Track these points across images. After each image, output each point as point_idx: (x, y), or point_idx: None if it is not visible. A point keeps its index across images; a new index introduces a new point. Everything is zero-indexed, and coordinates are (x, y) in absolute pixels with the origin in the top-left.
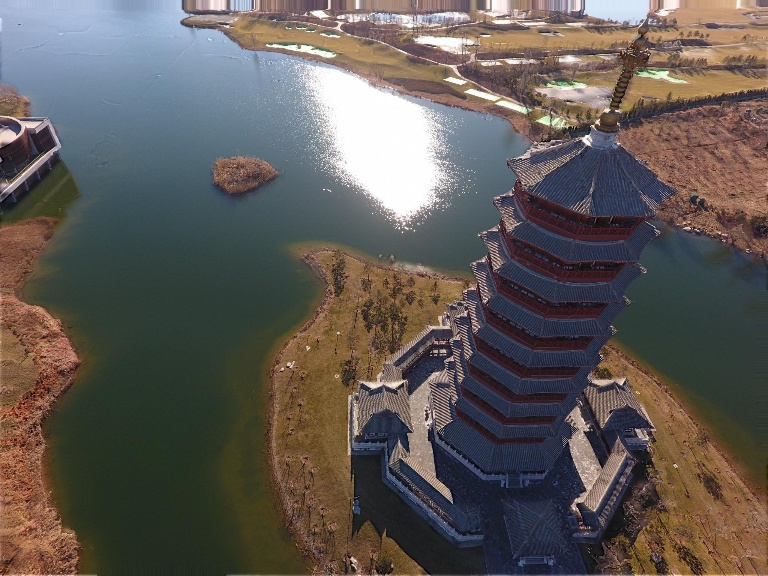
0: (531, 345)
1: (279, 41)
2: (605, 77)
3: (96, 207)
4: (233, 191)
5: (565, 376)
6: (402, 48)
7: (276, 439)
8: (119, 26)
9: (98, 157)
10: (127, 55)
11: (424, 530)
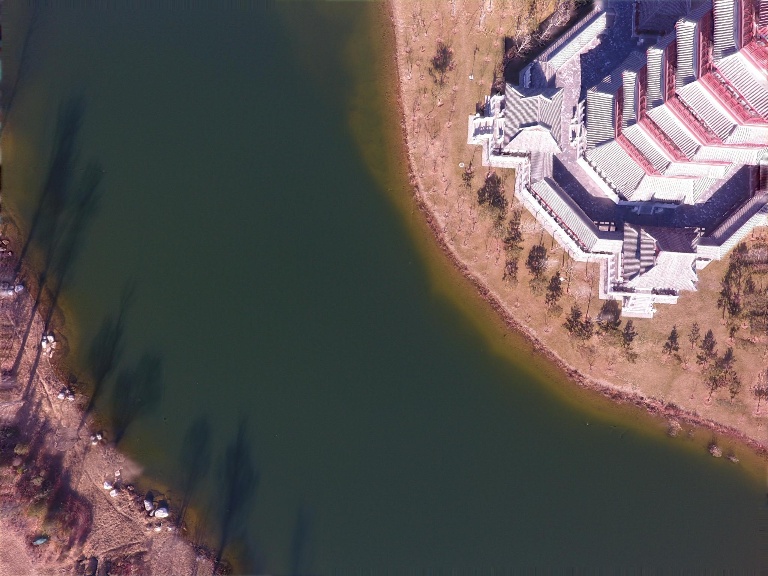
0: None
1: None
2: None
3: None
4: None
5: None
6: None
7: None
8: None
9: None
10: None
11: None
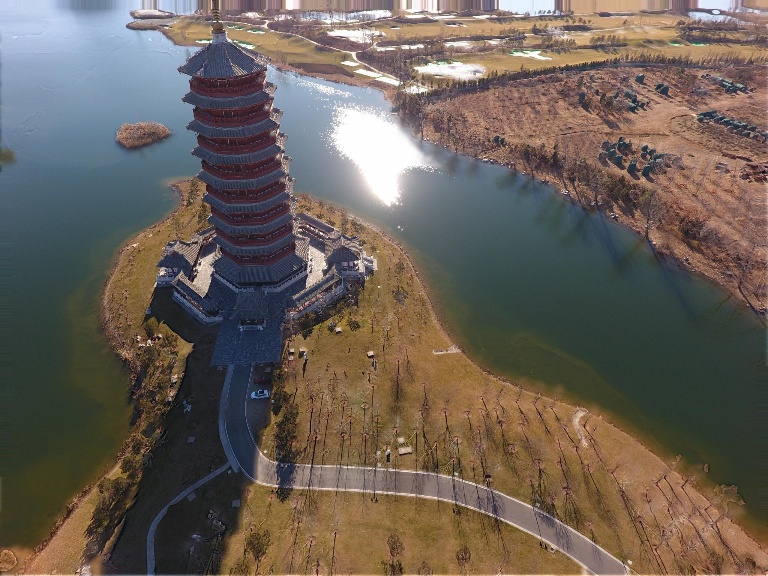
0: (219, 176)
1: (208, 37)
2: (481, 57)
3: None
4: (129, 145)
5: (254, 201)
6: (315, 40)
7: (111, 284)
8: (70, 30)
9: (26, 126)
10: (70, 52)
11: (189, 320)
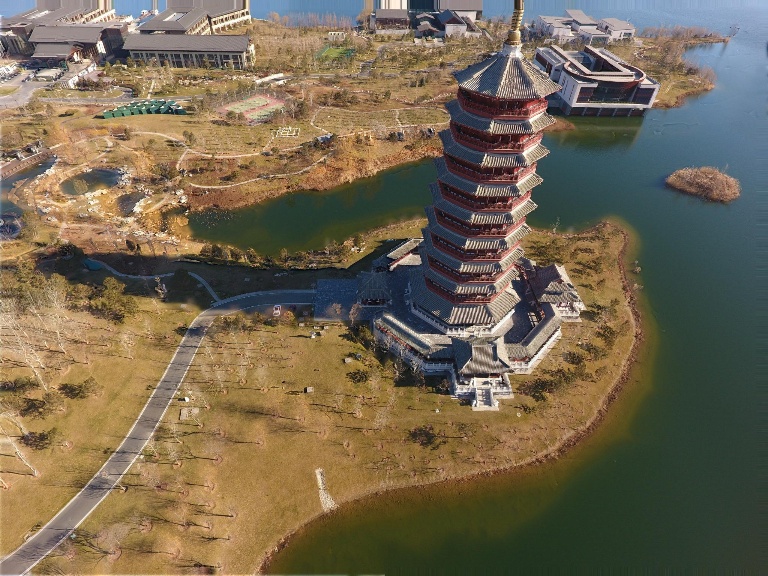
0: None
1: None
2: None
3: (603, 140)
4: (669, 181)
5: None
6: None
7: None
8: None
9: (661, 126)
10: None
11: None
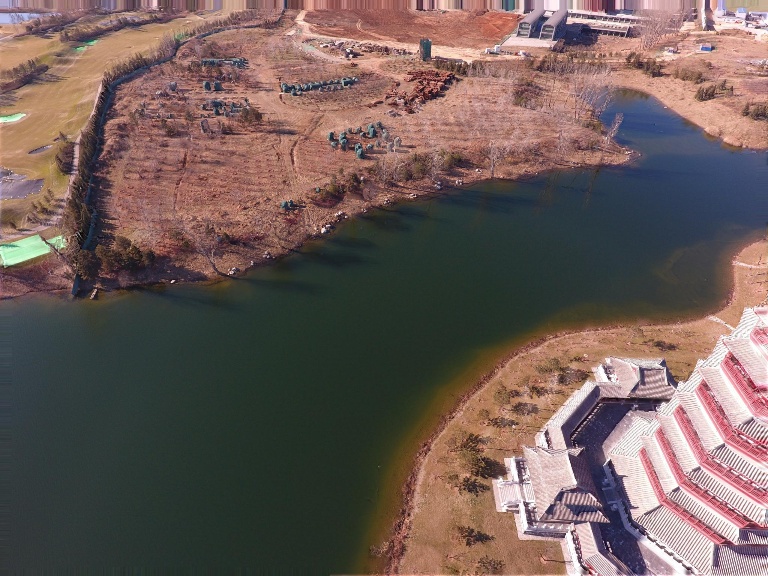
0: None
1: None
2: None
3: None
4: None
5: None
6: None
7: None
8: None
9: None
10: None
11: None
